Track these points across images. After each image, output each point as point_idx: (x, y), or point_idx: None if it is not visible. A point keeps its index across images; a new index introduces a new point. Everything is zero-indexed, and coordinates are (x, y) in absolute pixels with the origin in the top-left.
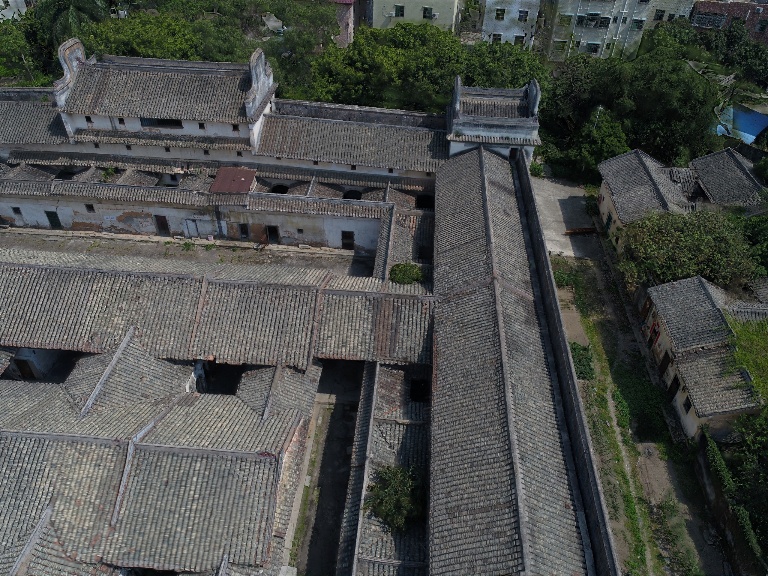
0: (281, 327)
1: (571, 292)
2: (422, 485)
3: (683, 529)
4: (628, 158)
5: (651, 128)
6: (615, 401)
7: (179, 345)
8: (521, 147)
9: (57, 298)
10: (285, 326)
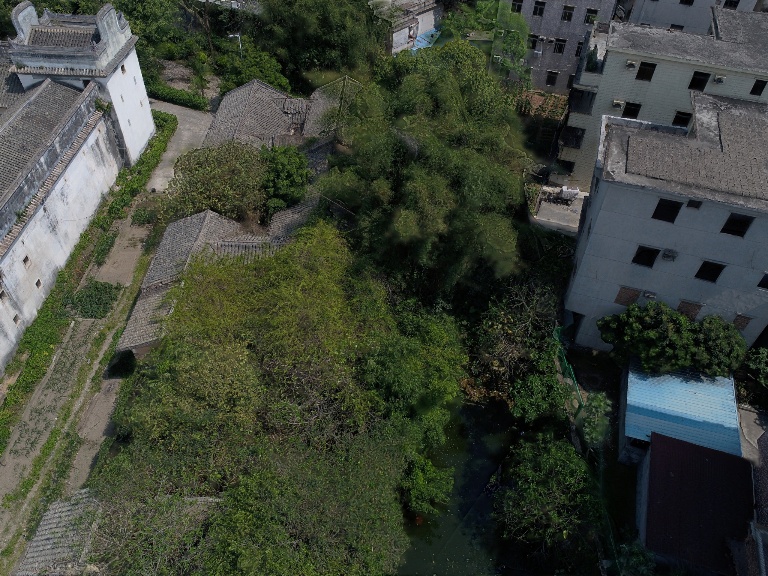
0: None
1: (148, 230)
2: None
3: (88, 461)
4: (246, 89)
5: (307, 57)
6: (113, 339)
7: None
8: (91, 79)
9: None
10: None
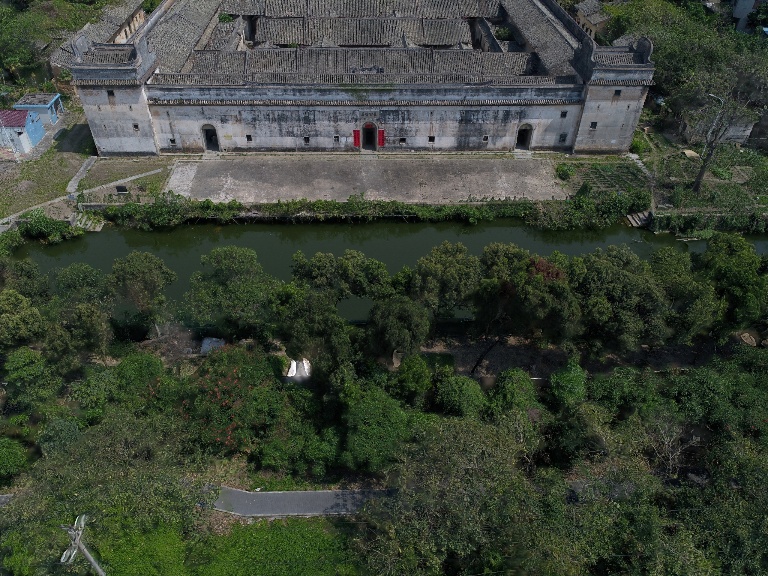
0: (447, 8)
1: None
2: (510, 30)
3: None
4: None
5: None
6: None
7: (413, 14)
8: None
9: (363, 3)
10: (449, 7)
